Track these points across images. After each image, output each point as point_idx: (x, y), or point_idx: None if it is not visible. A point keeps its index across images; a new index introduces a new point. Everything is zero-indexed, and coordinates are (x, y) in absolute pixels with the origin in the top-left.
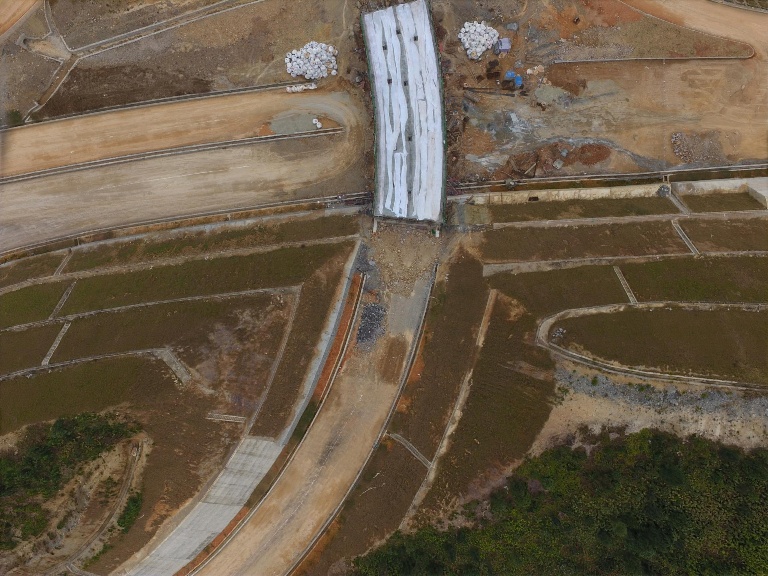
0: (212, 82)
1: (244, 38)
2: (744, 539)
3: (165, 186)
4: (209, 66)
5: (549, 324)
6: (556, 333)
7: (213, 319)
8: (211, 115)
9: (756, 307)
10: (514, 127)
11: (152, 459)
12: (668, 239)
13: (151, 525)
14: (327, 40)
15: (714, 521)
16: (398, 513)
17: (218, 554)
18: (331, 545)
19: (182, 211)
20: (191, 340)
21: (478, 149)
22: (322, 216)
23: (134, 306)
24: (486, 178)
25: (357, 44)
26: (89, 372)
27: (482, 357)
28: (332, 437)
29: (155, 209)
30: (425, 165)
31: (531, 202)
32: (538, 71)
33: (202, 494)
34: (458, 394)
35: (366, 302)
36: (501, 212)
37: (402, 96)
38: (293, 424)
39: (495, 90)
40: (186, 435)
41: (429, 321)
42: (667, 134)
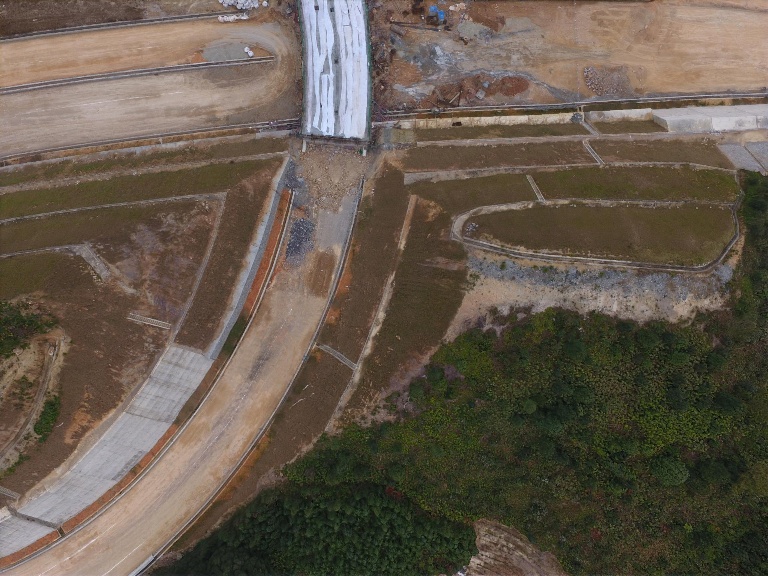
0: (144, 10)
1: None
2: (643, 410)
3: (96, 111)
4: None
5: (463, 220)
6: (469, 227)
7: (135, 220)
8: (143, 42)
9: (652, 204)
10: (439, 59)
11: (70, 359)
12: (578, 154)
13: (72, 437)
14: None
15: (615, 394)
16: (325, 416)
17: (146, 475)
18: (261, 459)
19: (113, 135)
20: (112, 238)
21: (405, 79)
22: (253, 138)
23: (56, 213)
24: (413, 106)
25: None
26: (3, 267)
27: (403, 259)
28: (262, 351)
29: (85, 133)
30: (351, 86)
31: (455, 127)
32: (460, 8)
33: (126, 404)
34: (381, 296)
35: (295, 218)
36: (425, 134)
37: (328, 22)
38: (222, 337)
39: (420, 24)
40: (106, 335)
41: (356, 234)
42: (580, 69)
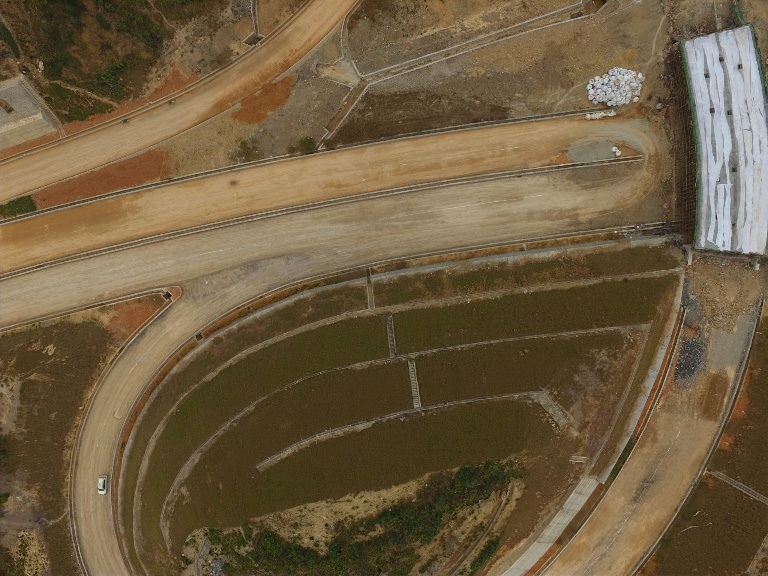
0: (510, 109)
1: (538, 63)
2: None
3: (458, 215)
4: (507, 92)
5: None
6: None
7: (576, 359)
8: (507, 142)
9: None
10: None
11: (519, 503)
12: None
13: None
14: (630, 66)
15: None
16: (742, 555)
17: None
18: None
19: (475, 241)
20: (561, 382)
21: None
22: (628, 247)
23: (478, 344)
24: None
25: (664, 70)
26: (468, 416)
27: None
28: (647, 474)
29: (447, 238)
30: (750, 197)
31: None
32: None
33: (537, 534)
34: None
35: (685, 337)
36: None
37: (726, 126)
38: (615, 462)
39: None
40: (549, 478)
41: (755, 357)
42: None
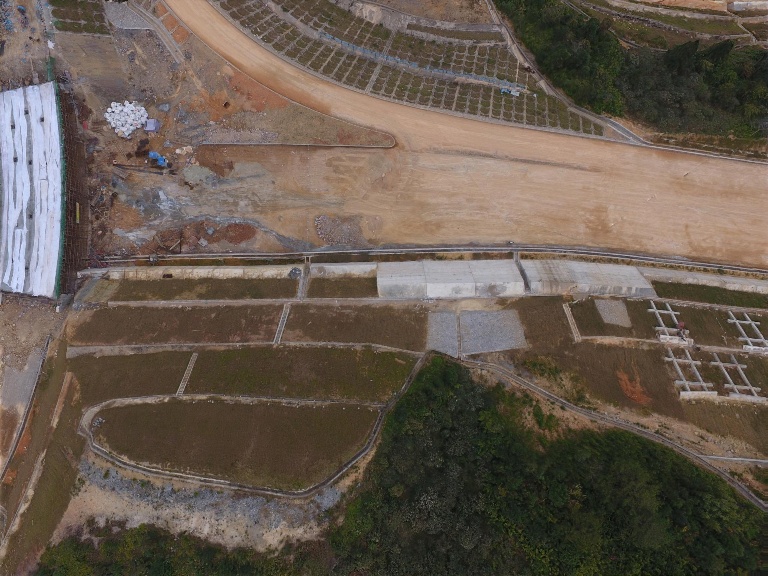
0: None
1: None
2: None
3: None
4: None
5: (94, 413)
6: (95, 422)
7: None
8: None
9: (296, 402)
10: (162, 204)
11: None
12: (264, 325)
13: None
14: None
15: None
16: None
17: None
18: None
19: None
20: None
21: (126, 224)
22: None
23: None
24: (130, 253)
25: None
26: None
27: (53, 438)
28: None
29: None
30: (43, 243)
31: (165, 279)
32: (186, 151)
33: None
34: (32, 473)
35: None
36: (126, 289)
37: (26, 175)
38: None
39: (144, 168)
40: None
41: (37, 395)
42: (311, 217)
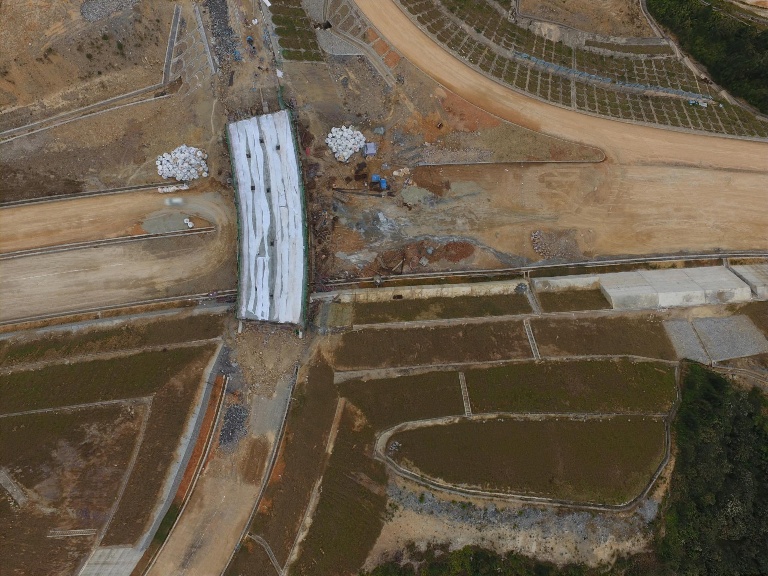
0: (83, 183)
1: (118, 139)
2: None
3: (35, 284)
4: (81, 167)
5: (387, 437)
6: (392, 447)
7: (57, 435)
8: (83, 215)
9: (583, 417)
10: (382, 226)
11: None
12: (515, 342)
13: None
14: (198, 143)
15: None
16: None
17: None
18: None
19: (52, 309)
20: (31, 459)
21: (347, 247)
22: (190, 315)
23: None
24: (354, 275)
25: (226, 148)
26: None
27: (331, 465)
28: (195, 539)
29: (24, 307)
30: (286, 269)
31: (395, 300)
32: (404, 173)
33: None
34: (308, 501)
35: (229, 403)
36: (364, 312)
37: (265, 202)
38: (152, 529)
39: (363, 191)
40: (26, 555)
41: (290, 422)
42: (527, 232)
